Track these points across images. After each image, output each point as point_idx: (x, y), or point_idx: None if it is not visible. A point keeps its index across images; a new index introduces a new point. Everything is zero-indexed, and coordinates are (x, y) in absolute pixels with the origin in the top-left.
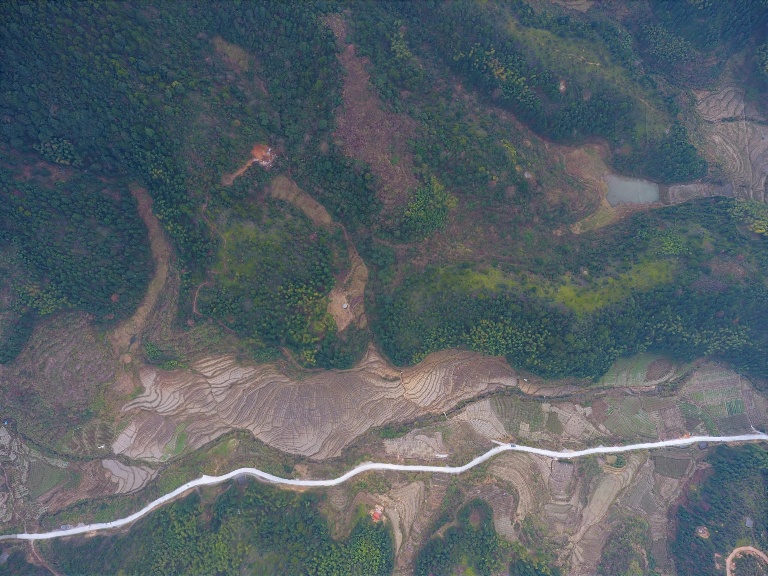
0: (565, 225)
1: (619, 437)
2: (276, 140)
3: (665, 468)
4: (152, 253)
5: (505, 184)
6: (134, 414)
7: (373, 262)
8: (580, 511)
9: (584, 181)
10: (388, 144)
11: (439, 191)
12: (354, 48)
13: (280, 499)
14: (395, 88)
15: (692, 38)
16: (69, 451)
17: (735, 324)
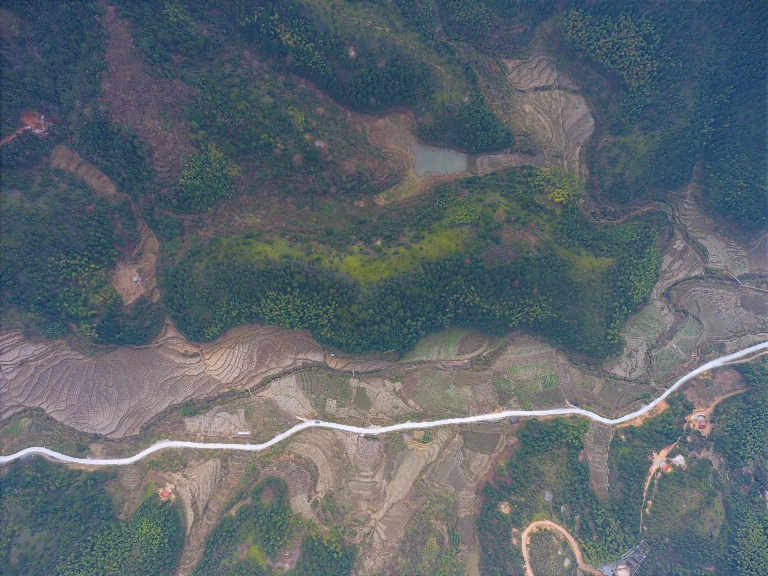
0: (368, 196)
1: (429, 412)
2: (48, 107)
3: (475, 443)
4: None
5: (292, 152)
6: None
7: (162, 234)
8: (384, 488)
9: (388, 151)
10: (159, 110)
11: (217, 159)
12: (114, 10)
13: (60, 478)
14: (163, 52)
15: (492, 4)
16: None
17: (536, 295)
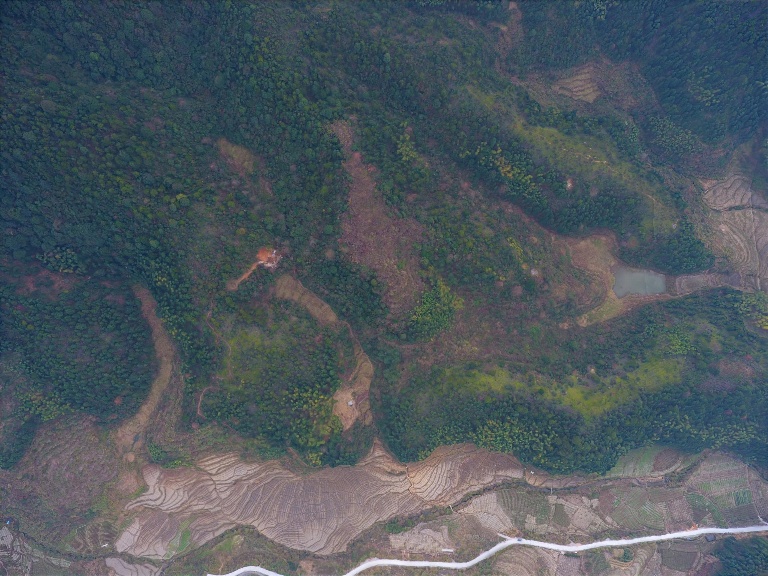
0: (572, 318)
1: (626, 529)
2: (281, 242)
3: (672, 561)
4: (156, 353)
5: (512, 284)
6: (138, 512)
7: (379, 360)
8: None
9: (591, 273)
10: (394, 249)
11: (445, 294)
12: (360, 156)
13: None
14: (401, 194)
15: (699, 131)
16: (72, 550)
17: (743, 420)
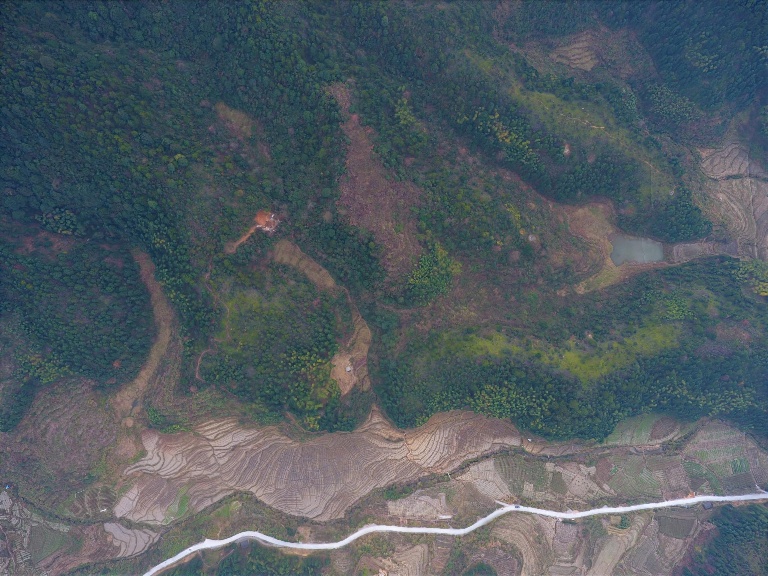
0: (569, 285)
1: (623, 497)
2: (279, 206)
3: (670, 528)
4: (154, 317)
5: (509, 248)
6: (136, 477)
7: (377, 325)
8: (584, 573)
9: (588, 241)
10: (392, 212)
11: (443, 257)
12: (358, 118)
13: (283, 566)
14: (399, 156)
15: (697, 99)
16: (71, 515)
17: (740, 386)
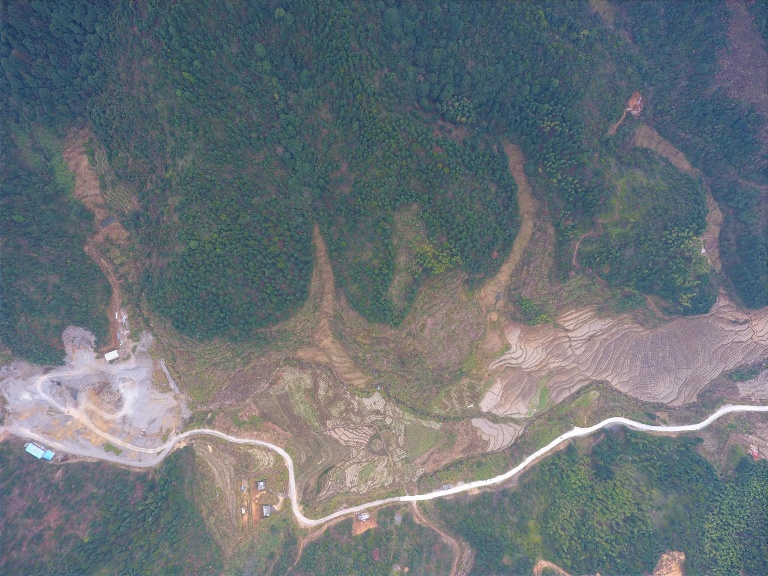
0: None
1: None
2: (647, 88)
3: None
4: (520, 209)
5: None
6: (499, 372)
7: (730, 205)
8: None
9: None
10: (767, 84)
11: None
12: None
13: (667, 443)
14: None
15: None
16: (440, 412)
17: None
